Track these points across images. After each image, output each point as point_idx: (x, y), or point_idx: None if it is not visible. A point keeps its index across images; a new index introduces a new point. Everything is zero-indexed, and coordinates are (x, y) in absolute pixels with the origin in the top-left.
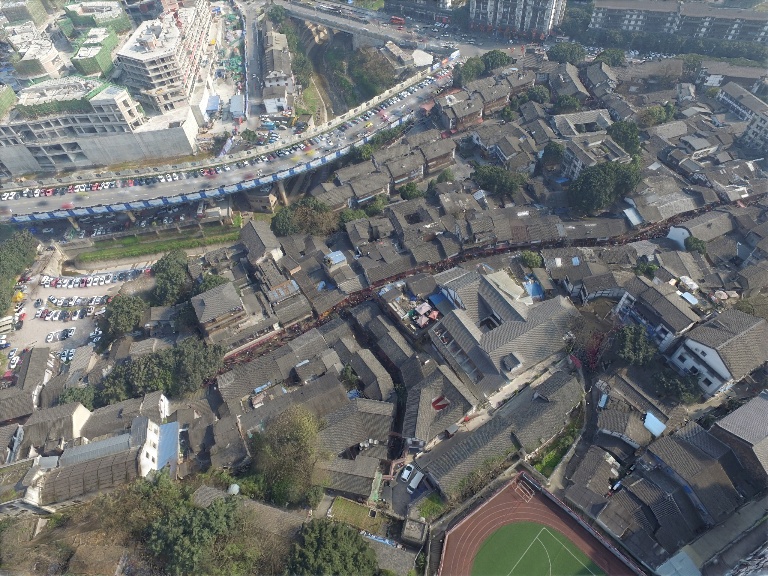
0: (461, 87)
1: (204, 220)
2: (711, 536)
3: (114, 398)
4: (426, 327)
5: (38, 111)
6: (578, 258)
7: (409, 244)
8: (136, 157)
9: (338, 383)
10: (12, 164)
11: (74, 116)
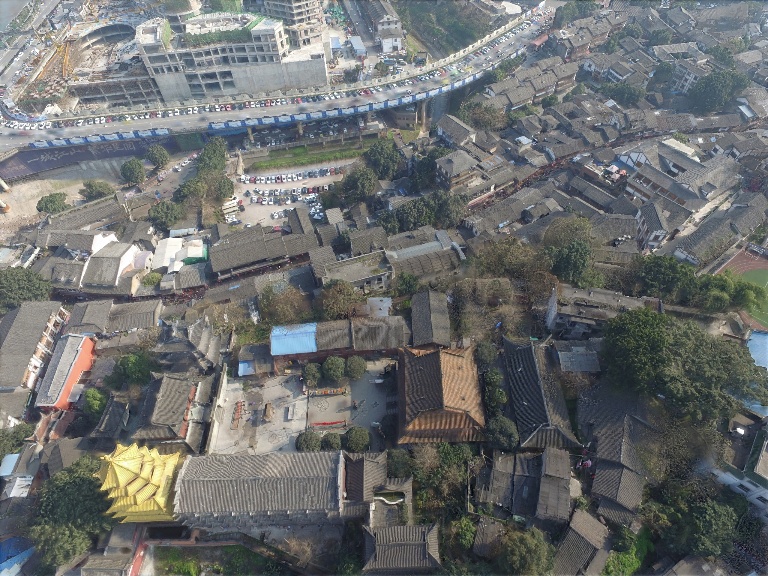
0: (560, 28)
1: (366, 132)
2: None
3: (391, 232)
4: (619, 181)
5: (202, 40)
6: (715, 138)
7: (579, 131)
8: (277, 87)
9: (571, 213)
10: (167, 91)
11: (232, 46)
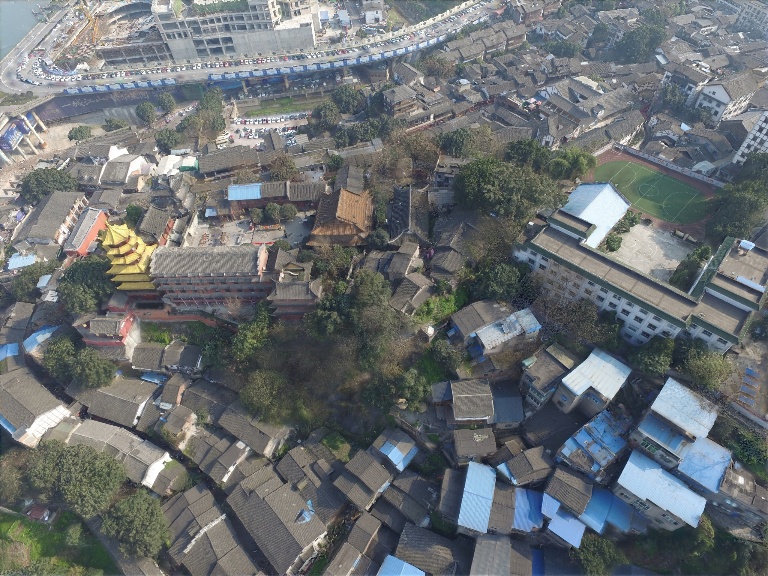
0: None
1: None
2: (720, 160)
3: (342, 146)
4: (535, 110)
5: (207, 10)
6: None
7: (512, 74)
8: None
9: None
10: (178, 55)
11: (233, 15)
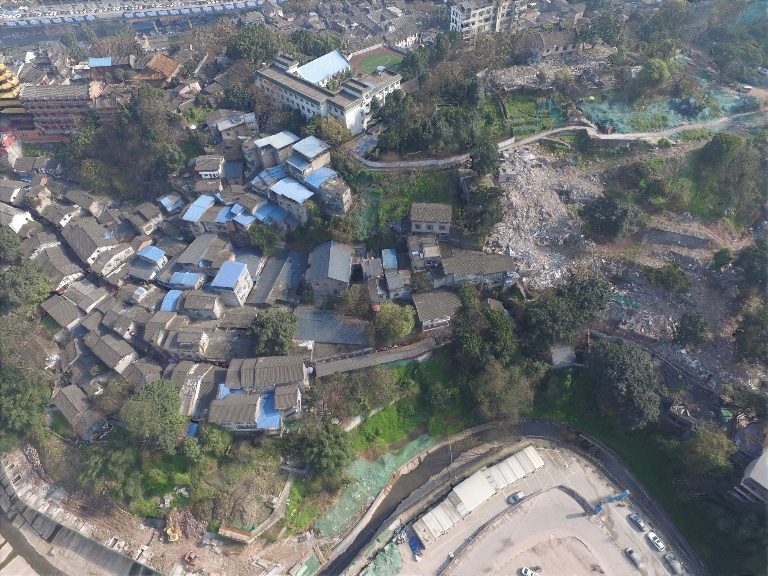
0: None
1: None
2: None
3: None
4: None
5: None
6: None
7: (351, 9)
8: None
9: None
10: None
11: None
